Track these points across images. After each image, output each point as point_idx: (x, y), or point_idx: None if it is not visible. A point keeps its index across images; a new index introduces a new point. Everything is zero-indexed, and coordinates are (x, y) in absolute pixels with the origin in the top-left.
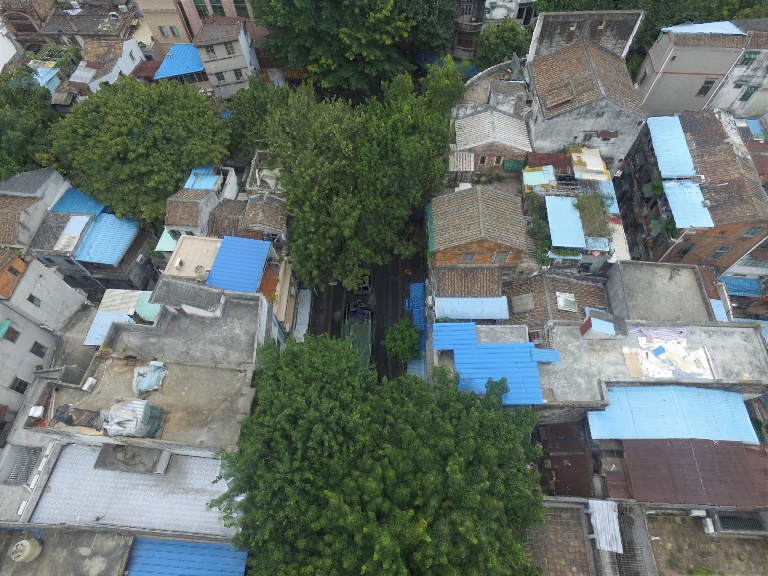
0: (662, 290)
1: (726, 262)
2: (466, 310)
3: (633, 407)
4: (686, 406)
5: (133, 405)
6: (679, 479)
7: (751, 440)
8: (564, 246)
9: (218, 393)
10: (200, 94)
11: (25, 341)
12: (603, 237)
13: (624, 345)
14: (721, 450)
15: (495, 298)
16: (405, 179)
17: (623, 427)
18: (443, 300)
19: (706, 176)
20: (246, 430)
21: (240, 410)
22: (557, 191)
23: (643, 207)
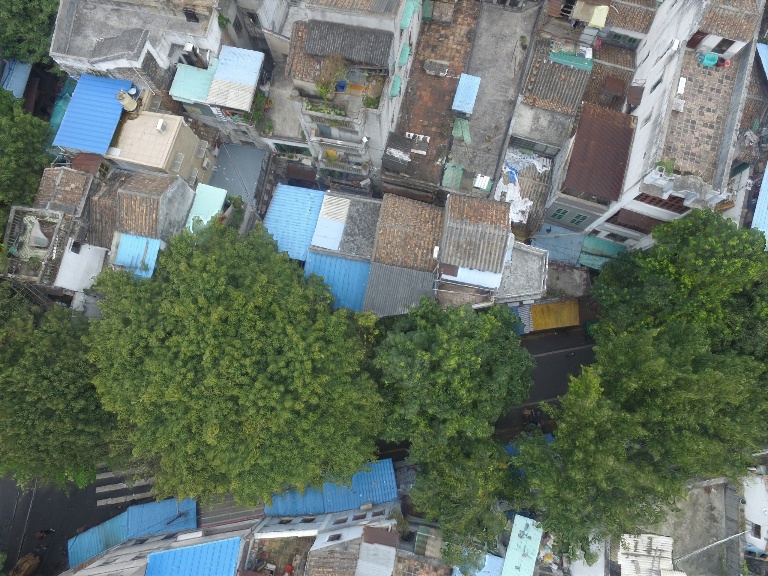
0: None
1: None
2: None
3: None
4: None
5: None
6: None
7: None
8: None
9: None
10: (106, 409)
11: None
12: None
13: None
14: None
15: None
16: None
17: None
18: None
19: None
20: None
21: None
22: None
23: None
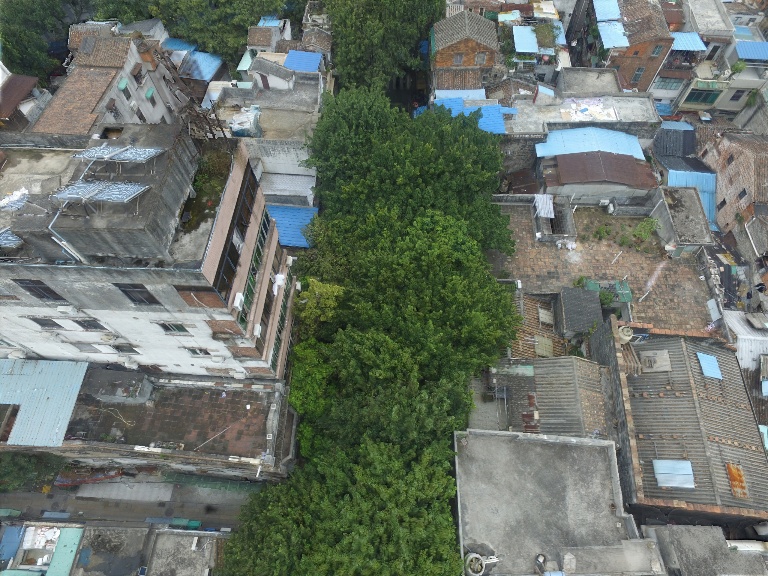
0: (591, 84)
1: (644, 85)
2: (457, 96)
3: (565, 139)
4: (598, 136)
5: (247, 115)
6: (590, 170)
7: (640, 157)
8: (524, 52)
9: (296, 123)
10: None
11: (158, 111)
12: (551, 48)
13: (561, 108)
14: (618, 158)
15: (477, 90)
16: (415, 10)
17: (557, 149)
18: (441, 91)
19: (628, 18)
20: (319, 124)
21: (313, 122)
22: (521, 24)
23: (588, 53)
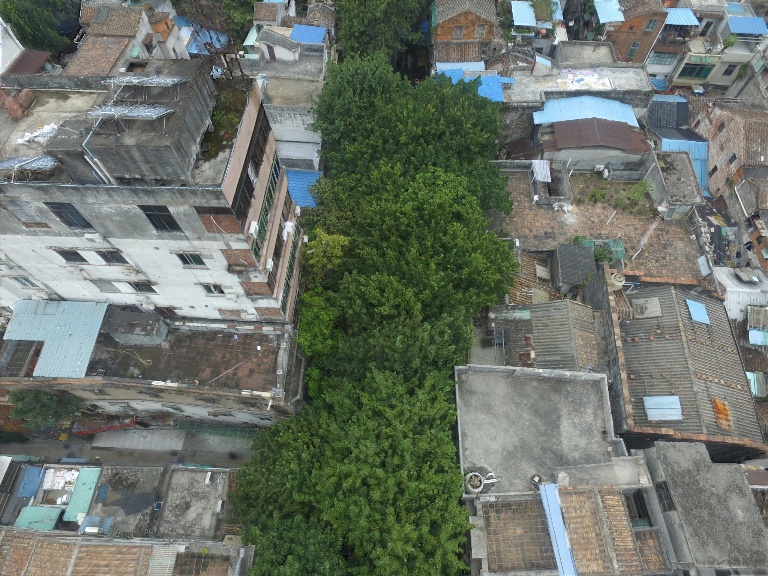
0: (587, 56)
1: (639, 60)
2: None
3: (561, 107)
4: (594, 104)
5: None
6: (585, 135)
7: (634, 124)
8: (522, 25)
9: (302, 91)
10: None
11: None
12: (548, 21)
13: (558, 78)
14: (613, 124)
15: (476, 62)
16: None
17: (554, 116)
18: (442, 64)
19: None
20: None
21: (319, 88)
22: None
23: (585, 30)
